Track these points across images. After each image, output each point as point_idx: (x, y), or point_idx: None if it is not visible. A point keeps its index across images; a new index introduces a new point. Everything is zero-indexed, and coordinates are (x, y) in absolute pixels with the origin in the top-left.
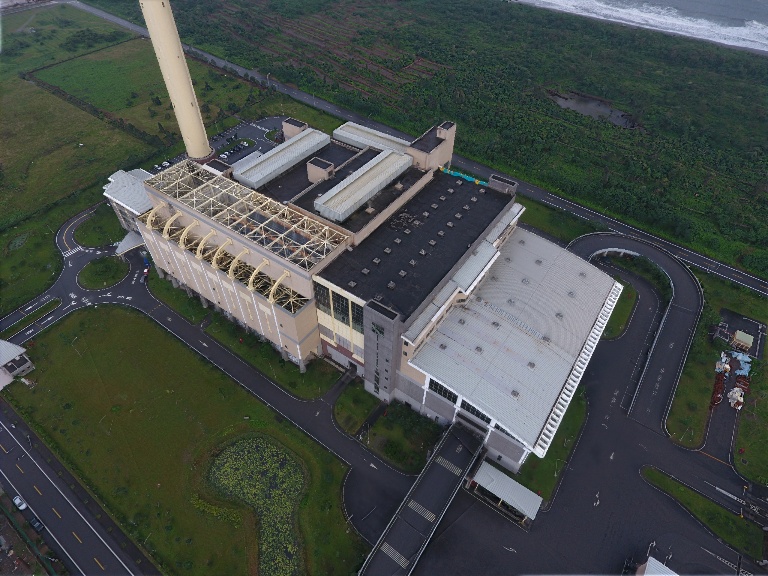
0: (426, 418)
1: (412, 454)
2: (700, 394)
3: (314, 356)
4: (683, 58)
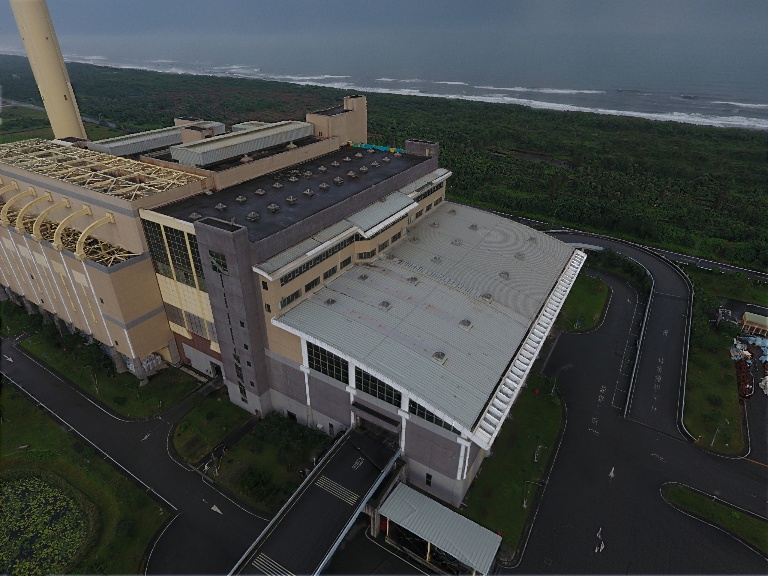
0: (315, 430)
1: (284, 484)
2: (721, 386)
3: (167, 365)
4: (614, 124)
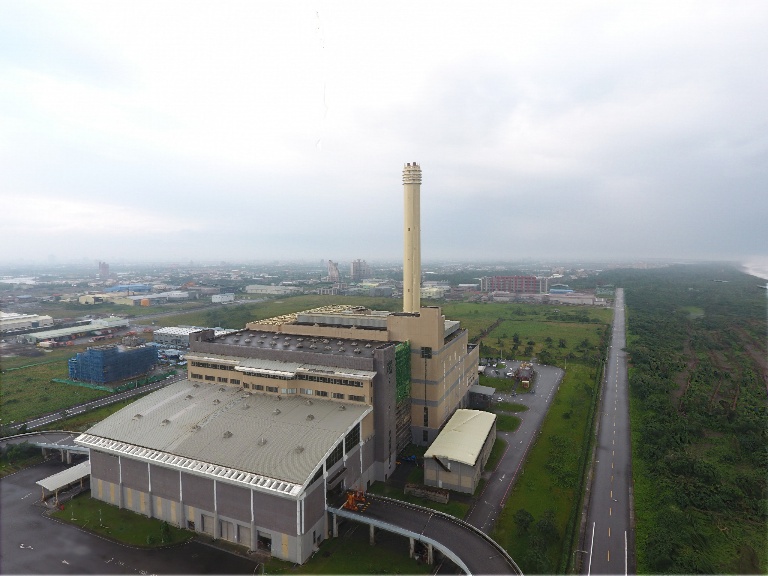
0: None
1: None
2: None
3: None
4: None
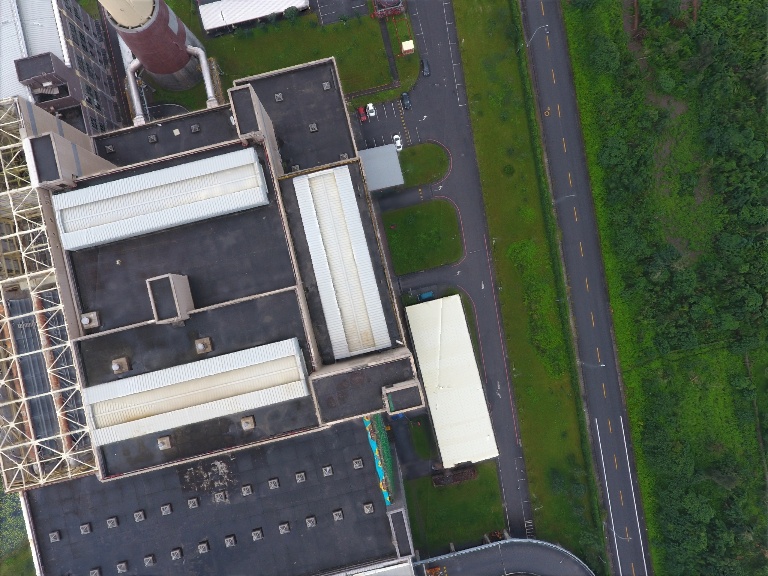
0: None
1: None
2: None
3: None
4: None
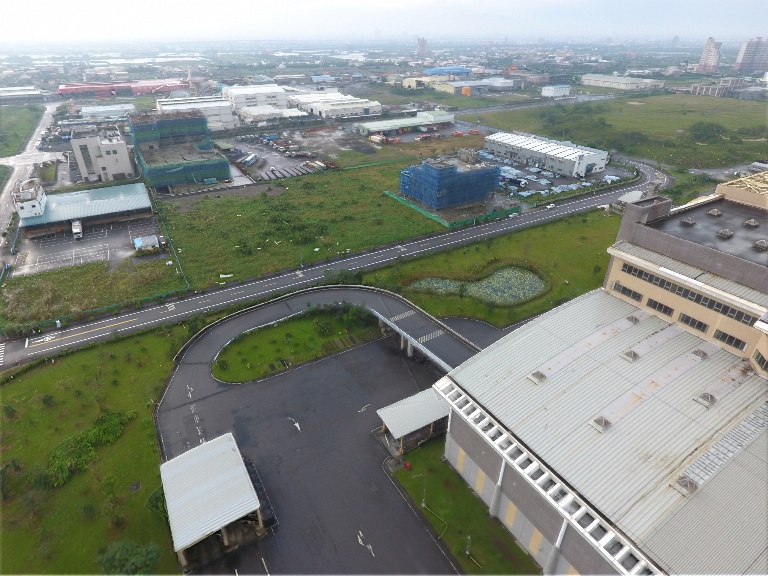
0: None
1: None
2: None
3: None
4: None
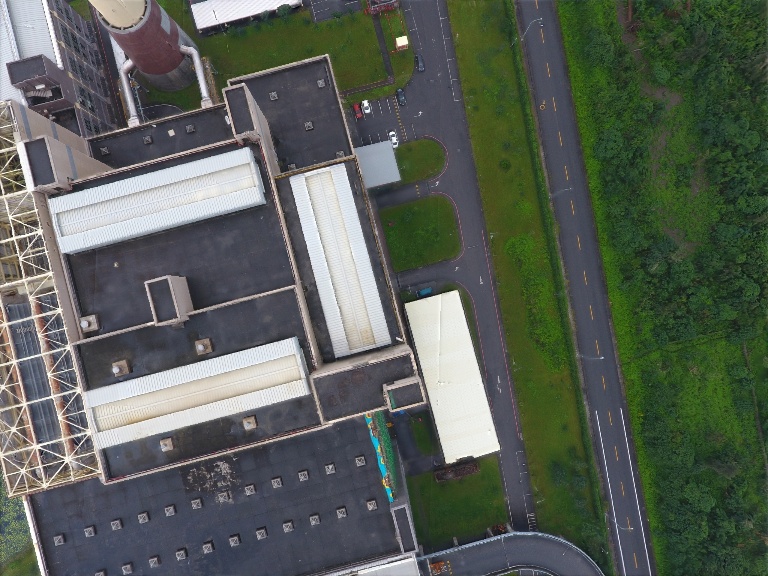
0: None
1: None
2: None
3: None
4: None
